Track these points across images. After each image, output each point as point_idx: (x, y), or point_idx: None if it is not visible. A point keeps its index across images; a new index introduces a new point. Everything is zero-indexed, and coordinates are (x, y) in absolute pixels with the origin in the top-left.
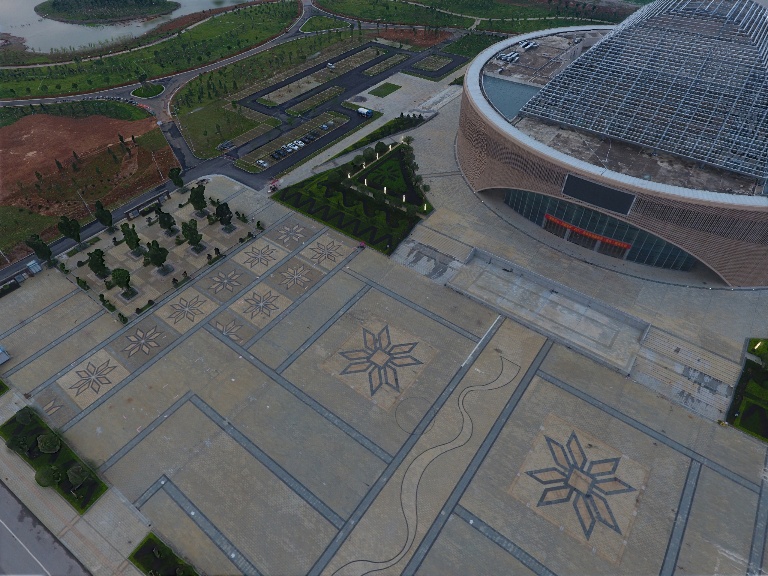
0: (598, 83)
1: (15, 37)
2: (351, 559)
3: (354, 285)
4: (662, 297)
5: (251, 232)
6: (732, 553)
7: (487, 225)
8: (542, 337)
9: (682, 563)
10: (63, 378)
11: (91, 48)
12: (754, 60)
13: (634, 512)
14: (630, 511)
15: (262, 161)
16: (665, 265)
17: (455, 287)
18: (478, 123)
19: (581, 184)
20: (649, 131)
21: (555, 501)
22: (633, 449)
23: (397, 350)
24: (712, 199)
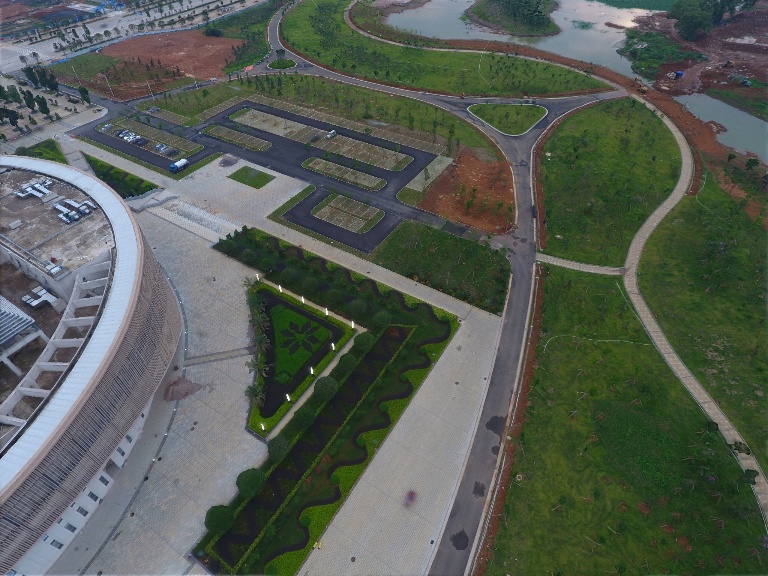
0: None
1: (422, 4)
2: None
3: None
4: None
5: None
6: None
7: None
8: None
9: None
10: None
11: None
12: None
13: None
14: None
15: (106, 125)
16: None
17: None
18: None
19: None
20: None
21: None
22: None
23: None
24: None
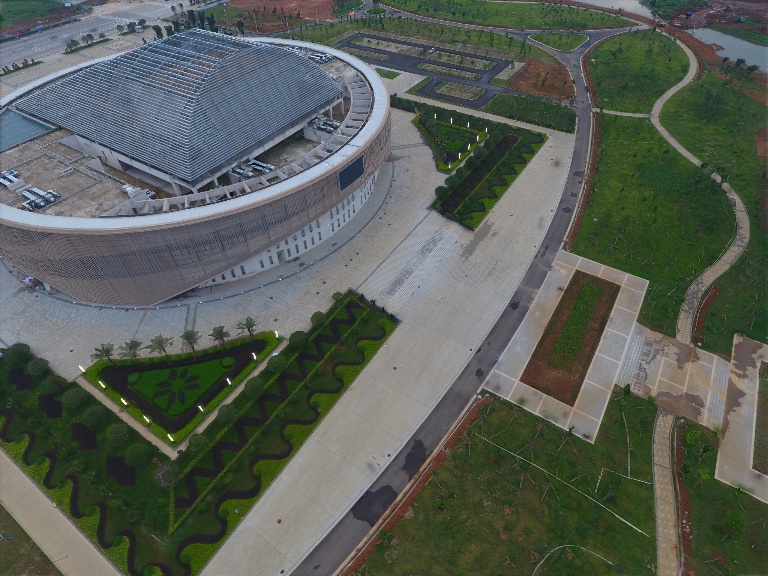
0: None
1: None
2: (2, 87)
3: None
4: None
5: None
6: None
7: None
8: None
9: None
10: (123, 41)
11: None
12: None
13: None
14: None
15: None
16: None
17: None
18: None
19: None
20: None
21: None
22: None
23: None
24: (19, 89)
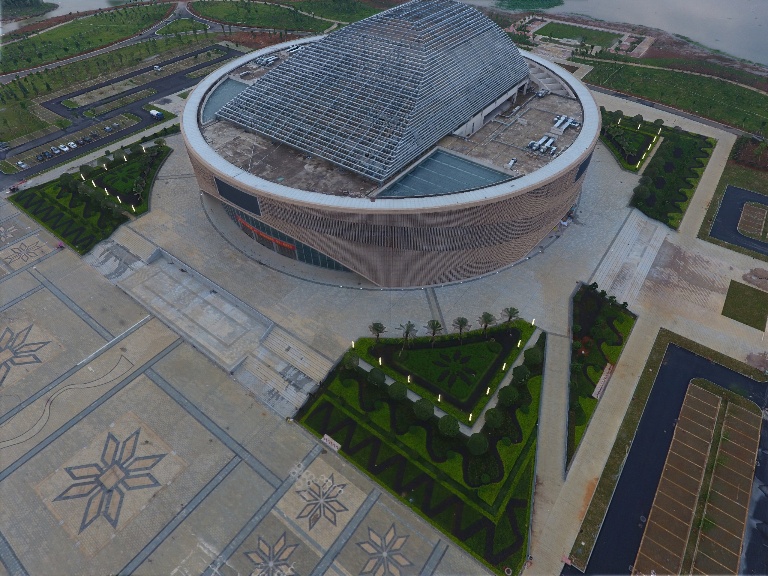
0: (287, 87)
1: None
2: None
3: (28, 285)
4: (308, 297)
5: None
6: (209, 546)
7: (190, 226)
8: (175, 336)
9: (154, 556)
10: None
11: None
12: (418, 65)
13: (143, 507)
14: (140, 506)
15: (21, 162)
16: (329, 266)
17: (121, 287)
18: None
19: (224, 186)
20: (308, 134)
21: (73, 496)
22: (185, 445)
23: (25, 349)
24: (315, 201)
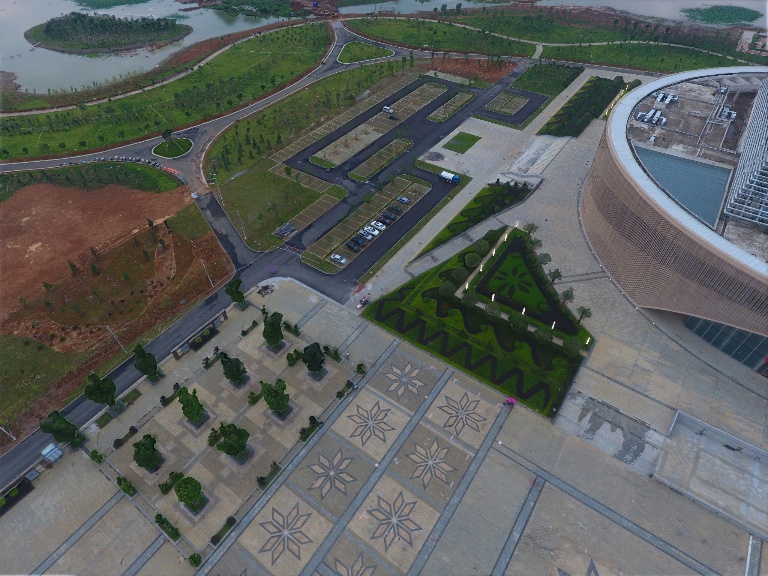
0: None
1: (4, 72)
2: None
3: (519, 478)
4: None
5: (349, 378)
6: None
7: (676, 366)
8: None
9: None
10: None
11: (96, 87)
12: None
13: None
14: None
15: (339, 256)
16: None
17: (670, 483)
18: (660, 226)
19: None
20: None
21: None
22: None
23: None
24: None
